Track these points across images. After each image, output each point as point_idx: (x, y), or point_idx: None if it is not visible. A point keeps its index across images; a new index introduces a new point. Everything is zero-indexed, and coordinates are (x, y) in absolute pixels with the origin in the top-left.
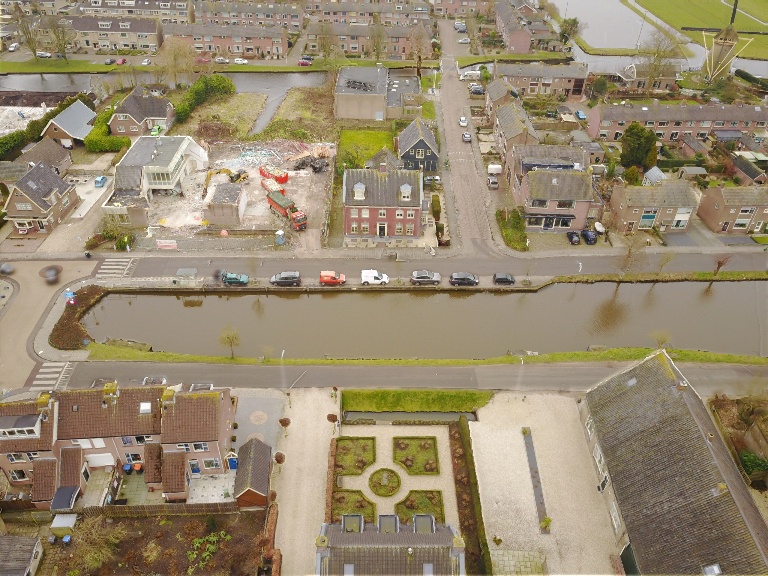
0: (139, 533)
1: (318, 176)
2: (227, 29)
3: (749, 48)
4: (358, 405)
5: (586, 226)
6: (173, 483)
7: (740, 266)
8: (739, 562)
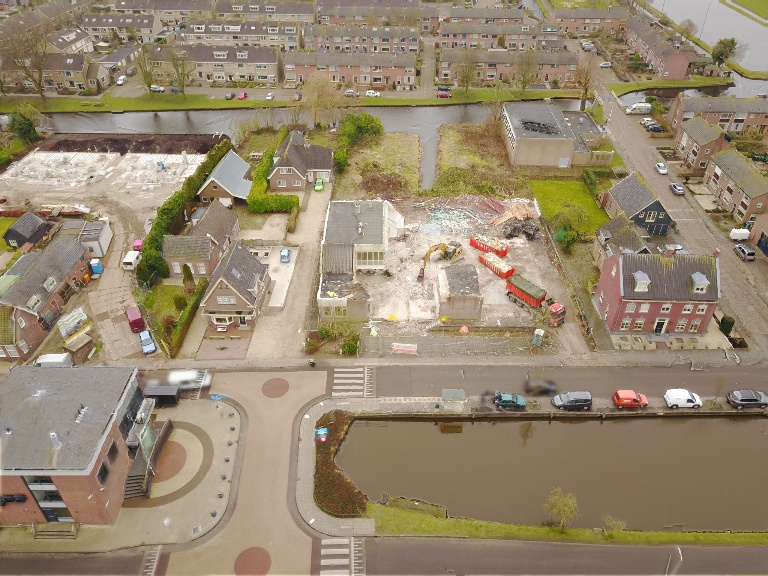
0: None
1: (534, 245)
2: (354, 58)
3: None
4: None
5: None
6: None
7: None
8: None
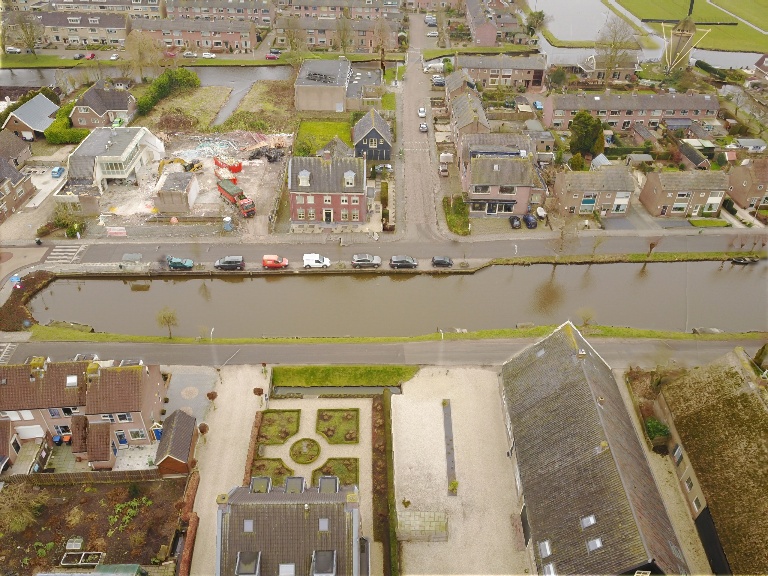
0: (63, 499)
1: (273, 165)
2: (195, 24)
3: (707, 39)
4: (288, 380)
5: (528, 211)
6: (98, 452)
7: (674, 248)
8: (611, 512)
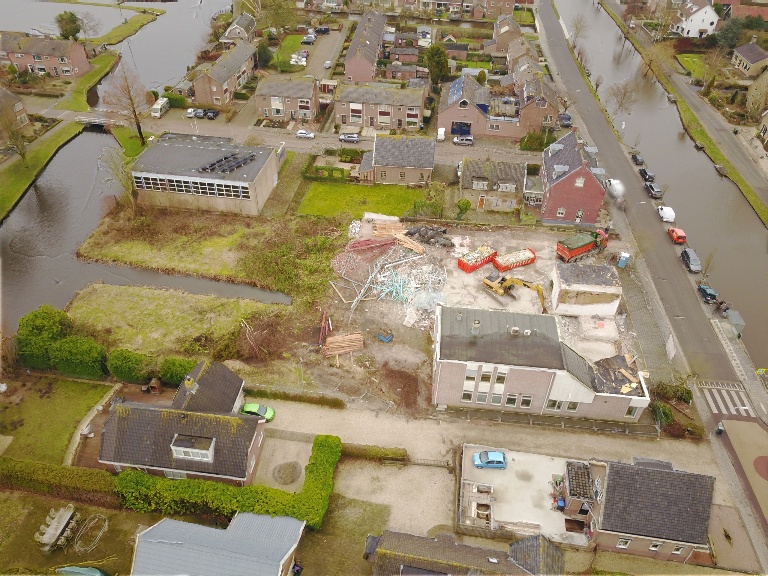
0: None
1: None
2: None
3: None
4: None
5: None
6: None
7: None
8: None
